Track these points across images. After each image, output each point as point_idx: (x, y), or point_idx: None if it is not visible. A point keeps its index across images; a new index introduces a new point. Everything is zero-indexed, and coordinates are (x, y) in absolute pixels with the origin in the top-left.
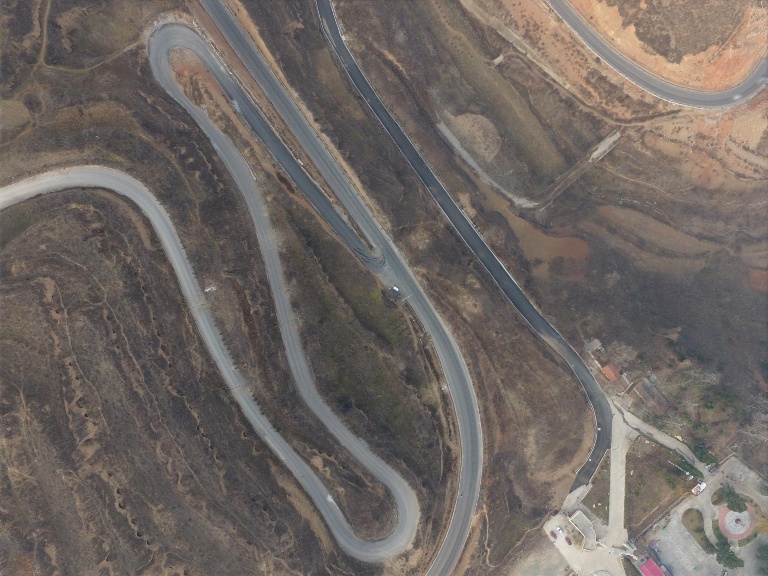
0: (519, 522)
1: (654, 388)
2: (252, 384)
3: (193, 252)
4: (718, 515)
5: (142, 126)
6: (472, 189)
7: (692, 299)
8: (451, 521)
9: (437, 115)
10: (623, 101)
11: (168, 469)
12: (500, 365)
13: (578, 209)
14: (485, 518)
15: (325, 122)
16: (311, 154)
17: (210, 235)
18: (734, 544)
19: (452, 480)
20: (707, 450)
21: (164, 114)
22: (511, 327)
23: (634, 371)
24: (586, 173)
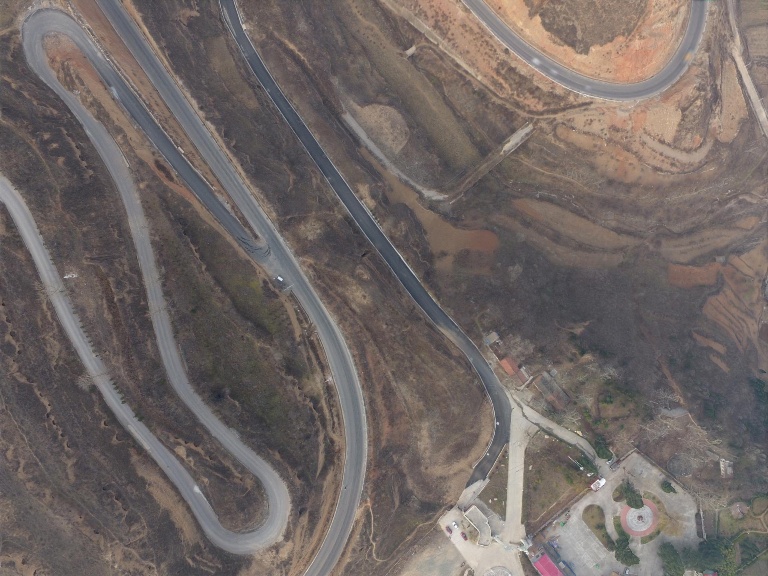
0: (410, 516)
1: (554, 382)
2: (114, 372)
3: (51, 238)
4: (620, 512)
5: (2, 111)
6: (372, 180)
7: (603, 293)
8: (334, 514)
9: (342, 105)
10: (534, 93)
11: (8, 456)
12: (391, 357)
13: (492, 202)
14: (369, 511)
15: (211, 110)
16: (197, 142)
17: (71, 221)
18: (636, 541)
19: (336, 473)
20: (608, 445)
21: (29, 99)
22: (401, 319)
23: (534, 365)
24: (502, 166)
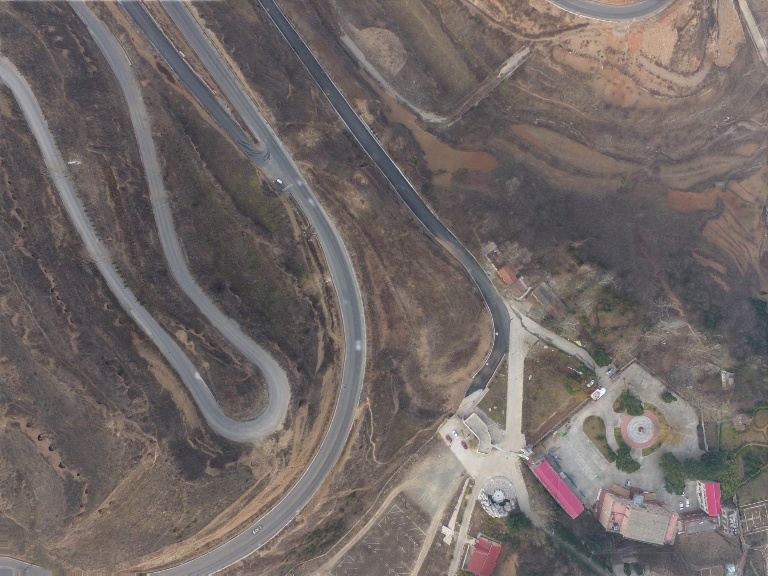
0: (410, 422)
1: (552, 292)
2: (117, 258)
3: (56, 124)
4: (620, 423)
5: (9, 3)
6: (370, 96)
7: (601, 213)
8: (334, 413)
9: (341, 28)
10: (530, 15)
11: (13, 322)
12: (389, 262)
13: (490, 127)
14: (368, 411)
15: (211, 18)
16: (197, 50)
17: (75, 110)
18: (638, 453)
19: (335, 372)
20: (608, 356)
21: None
22: (399, 224)
23: (533, 276)
24: (500, 93)
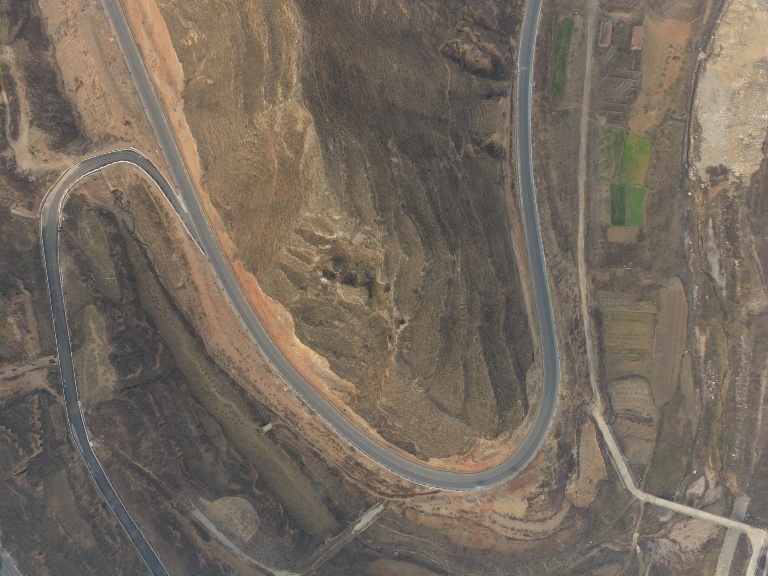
0: None
1: None
2: None
3: None
4: None
5: None
6: None
7: None
8: None
9: (191, 503)
10: (381, 483)
11: None
12: None
13: None
14: None
15: None
16: None
17: None
18: None
19: None
20: None
21: None
22: None
23: None
24: None
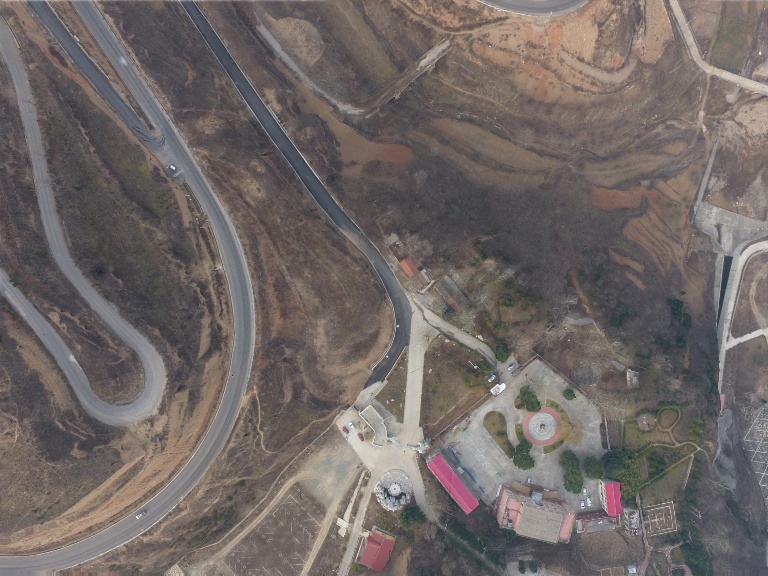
0: (304, 412)
1: (455, 286)
2: None
3: None
4: (522, 419)
5: None
6: (279, 85)
7: (516, 208)
8: (221, 401)
9: (257, 17)
10: (449, 7)
11: None
12: (285, 251)
13: (411, 120)
14: (255, 399)
15: (110, 4)
16: (96, 35)
17: None
18: (539, 450)
19: (224, 360)
20: (510, 351)
21: None
22: (296, 213)
23: (436, 269)
24: (423, 86)
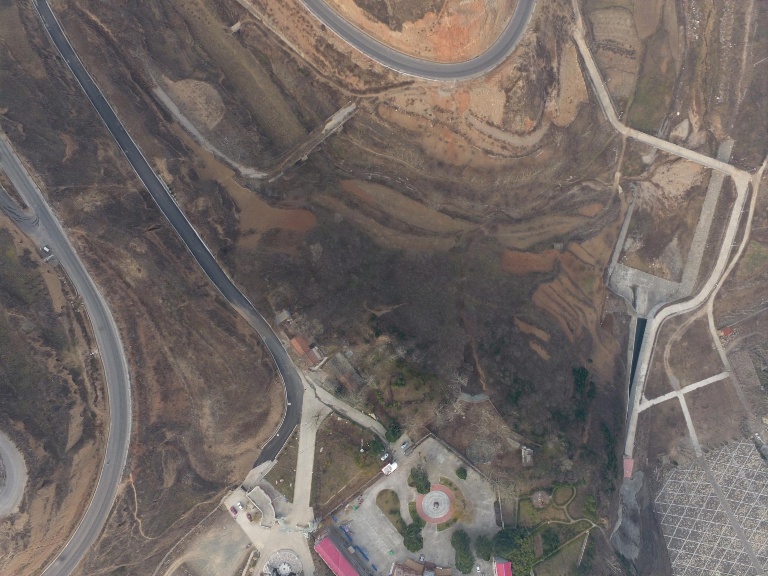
0: (187, 495)
1: (347, 363)
2: None
3: None
4: (415, 497)
5: None
6: (171, 154)
7: (420, 276)
8: (96, 489)
9: (153, 79)
10: (353, 71)
11: None
12: (168, 332)
13: (319, 182)
14: (131, 487)
15: None
16: None
17: None
18: (433, 528)
19: (99, 447)
20: (403, 429)
21: None
22: (178, 294)
23: (329, 346)
24: (332, 146)
